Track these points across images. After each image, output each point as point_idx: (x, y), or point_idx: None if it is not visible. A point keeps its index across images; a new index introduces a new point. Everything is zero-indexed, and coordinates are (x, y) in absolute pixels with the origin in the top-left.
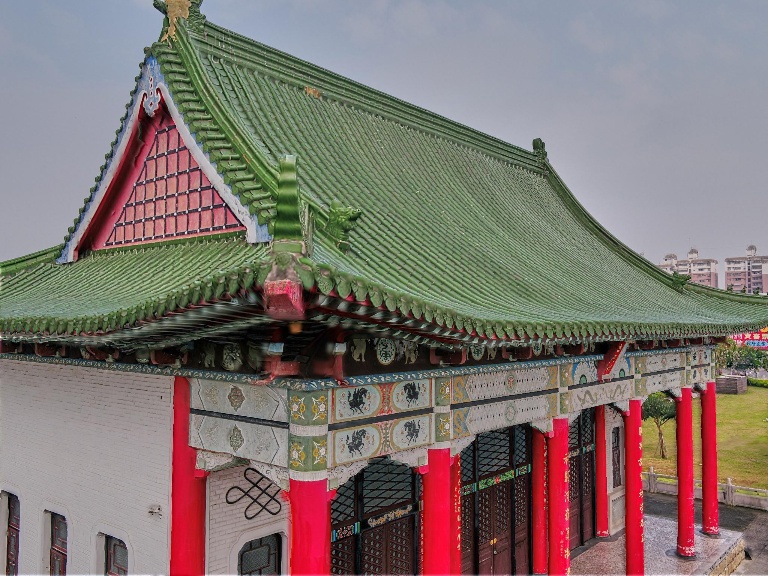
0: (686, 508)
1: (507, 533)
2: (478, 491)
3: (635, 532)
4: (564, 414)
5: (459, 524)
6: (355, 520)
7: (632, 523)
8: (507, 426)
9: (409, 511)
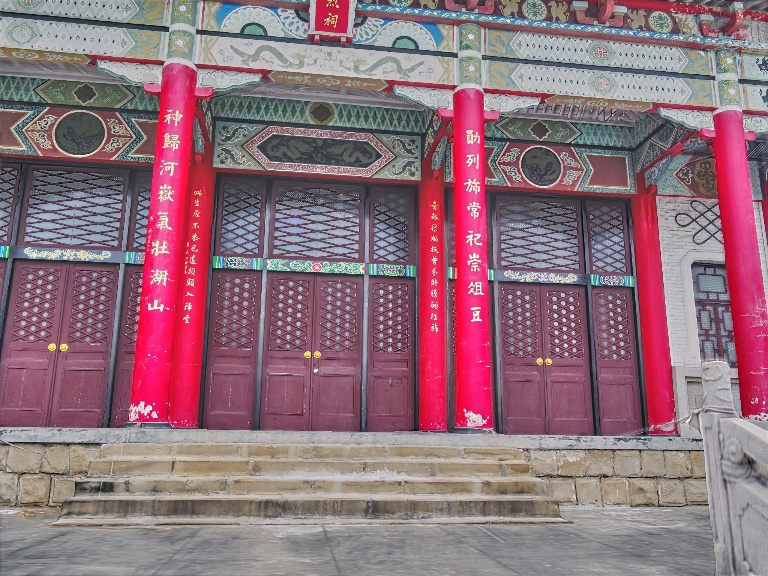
0: (742, 335)
1: (353, 354)
2: (267, 271)
3: (460, 304)
4: (172, 58)
5: (191, 290)
6: (5, 244)
7: (457, 290)
8: (13, 48)
9: (106, 258)
